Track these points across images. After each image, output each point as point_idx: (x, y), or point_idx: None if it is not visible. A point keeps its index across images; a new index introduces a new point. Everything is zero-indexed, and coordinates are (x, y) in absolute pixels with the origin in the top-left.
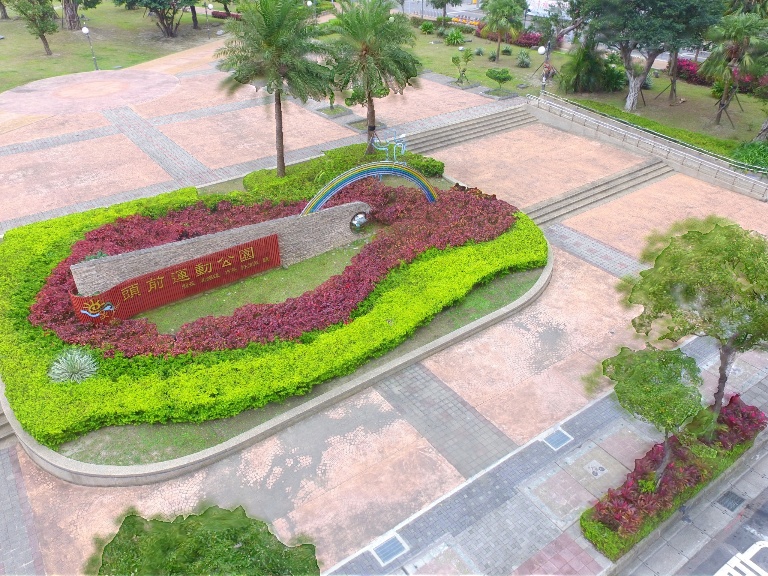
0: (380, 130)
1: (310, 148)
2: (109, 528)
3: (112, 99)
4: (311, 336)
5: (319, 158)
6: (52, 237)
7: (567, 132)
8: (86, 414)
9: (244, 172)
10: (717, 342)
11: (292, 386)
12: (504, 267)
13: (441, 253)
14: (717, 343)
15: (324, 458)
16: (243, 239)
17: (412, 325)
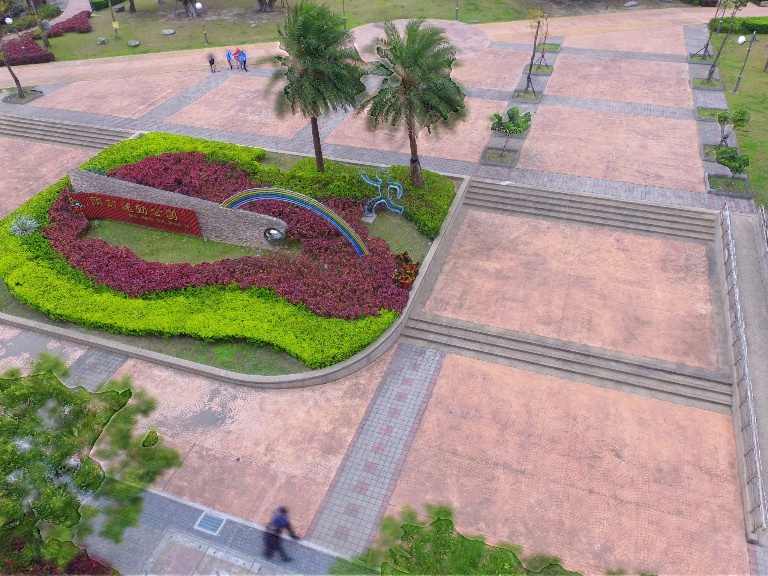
0: (502, 167)
1: None
2: None
3: None
4: (103, 290)
5: None
6: (154, 147)
7: (708, 274)
8: None
9: (332, 154)
10: (267, 552)
11: (44, 308)
12: (273, 342)
13: (270, 298)
14: (264, 553)
15: (5, 359)
16: (172, 202)
17: (141, 327)
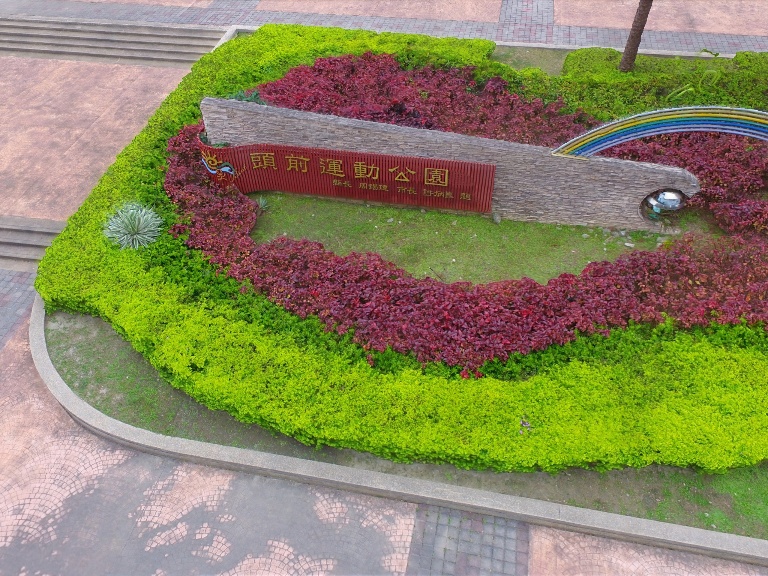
0: None
1: (730, 37)
2: (0, 445)
3: None
4: (393, 362)
5: (716, 60)
6: (290, 49)
7: None
8: (82, 294)
9: (592, 43)
10: None
11: (287, 427)
12: None
13: (765, 346)
14: None
15: (239, 568)
16: (440, 152)
17: (555, 459)
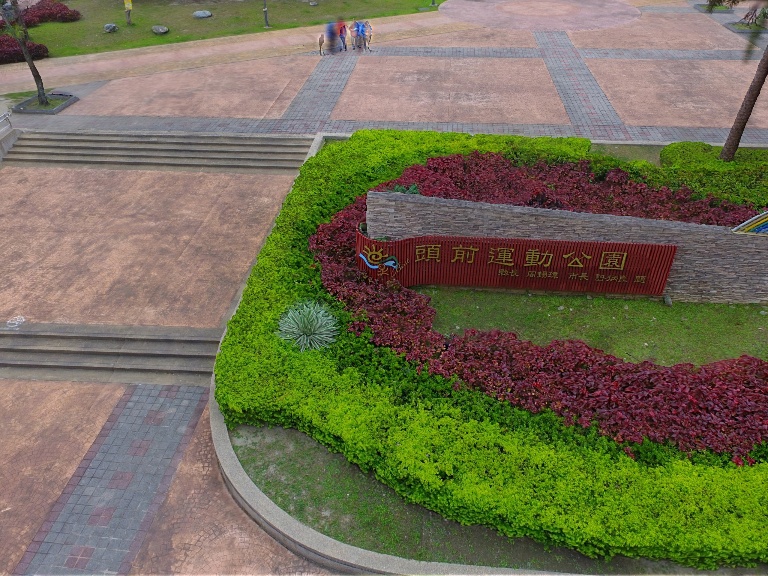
0: None
1: None
2: None
3: (552, 21)
4: (657, 453)
5: None
6: (394, 151)
7: None
8: (278, 402)
9: (670, 139)
10: None
11: (577, 536)
12: None
13: None
14: None
15: None
16: (617, 235)
17: None
